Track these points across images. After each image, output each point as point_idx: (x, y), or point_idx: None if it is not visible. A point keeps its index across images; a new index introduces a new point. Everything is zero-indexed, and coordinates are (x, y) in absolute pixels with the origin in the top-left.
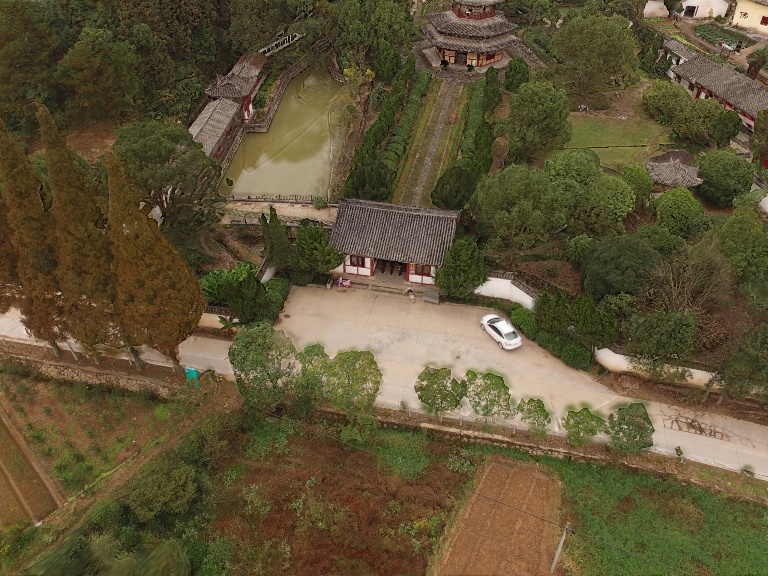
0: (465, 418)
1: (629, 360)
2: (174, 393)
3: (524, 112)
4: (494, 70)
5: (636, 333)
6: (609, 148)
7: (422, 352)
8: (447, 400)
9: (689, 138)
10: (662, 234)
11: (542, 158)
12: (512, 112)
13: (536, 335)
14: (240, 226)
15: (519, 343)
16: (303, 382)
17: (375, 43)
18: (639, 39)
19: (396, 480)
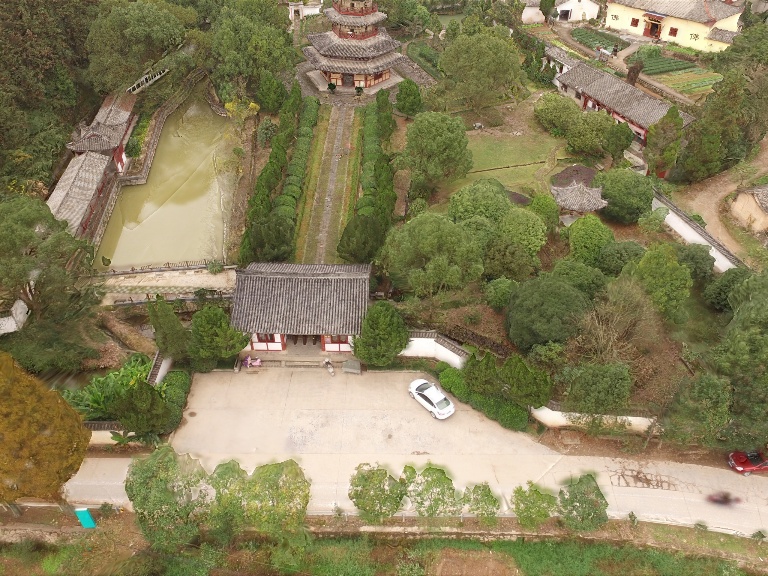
0: (407, 514)
1: (568, 417)
2: (65, 538)
3: (422, 144)
4: (384, 93)
5: (572, 391)
6: (510, 168)
7: (350, 436)
8: (386, 505)
9: (584, 151)
10: (579, 270)
11: (445, 186)
12: (410, 143)
13: (469, 398)
14: (125, 306)
15: (452, 410)
16: (219, 511)
17: (255, 73)
18: (521, 47)
19: None
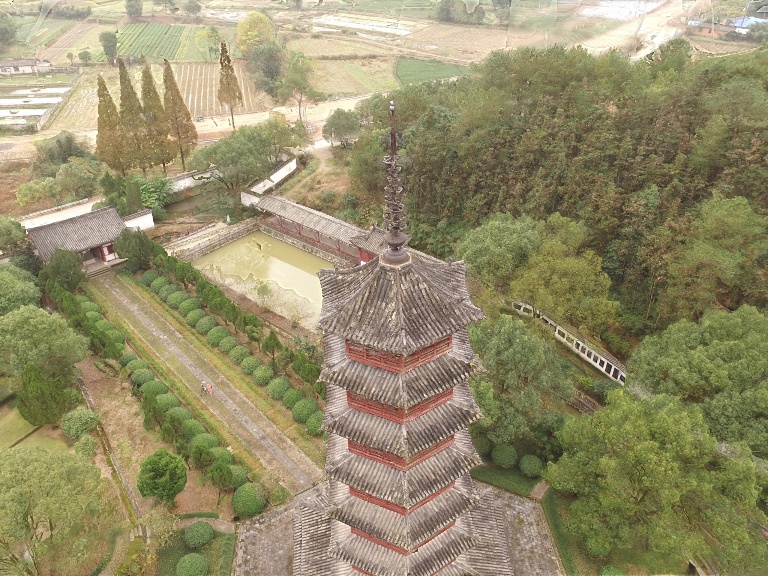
0: None
1: None
2: None
3: None
4: None
5: None
6: None
7: None
8: None
9: None
10: None
11: None
12: None
13: None
14: None
15: None
16: None
17: None
18: None
19: (1, 215)
